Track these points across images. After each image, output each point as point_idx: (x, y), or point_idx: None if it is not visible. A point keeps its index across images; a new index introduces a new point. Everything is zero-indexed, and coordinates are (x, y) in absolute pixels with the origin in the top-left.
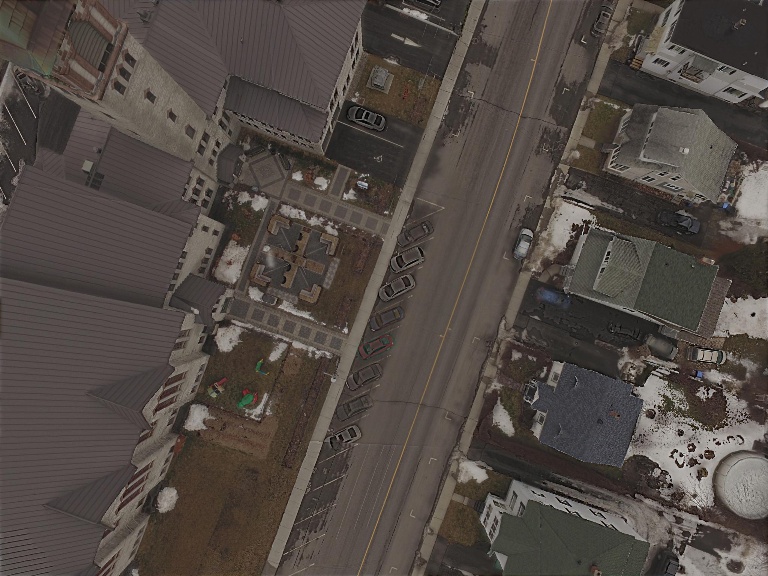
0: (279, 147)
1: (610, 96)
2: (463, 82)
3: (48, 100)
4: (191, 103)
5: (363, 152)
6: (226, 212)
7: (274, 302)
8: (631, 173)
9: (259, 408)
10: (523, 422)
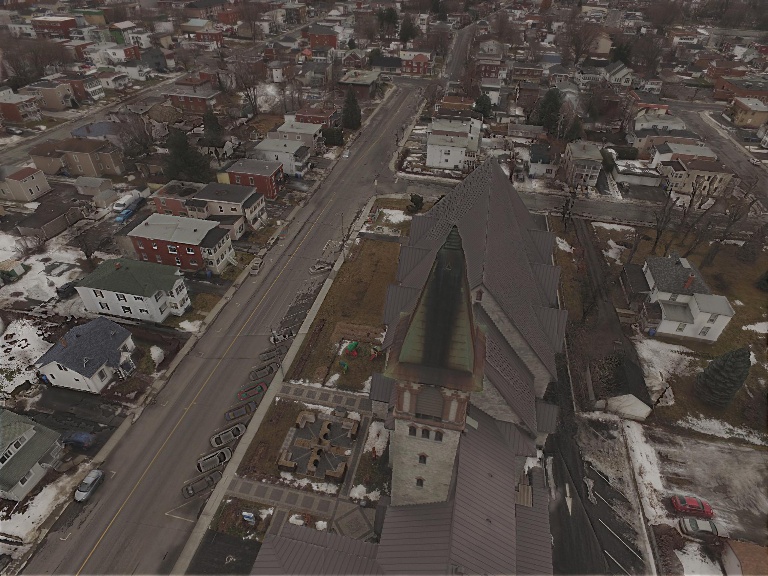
0: None
1: None
2: None
3: (603, 574)
4: None
5: (247, 565)
6: (390, 480)
7: None
8: None
9: (345, 346)
10: (141, 353)
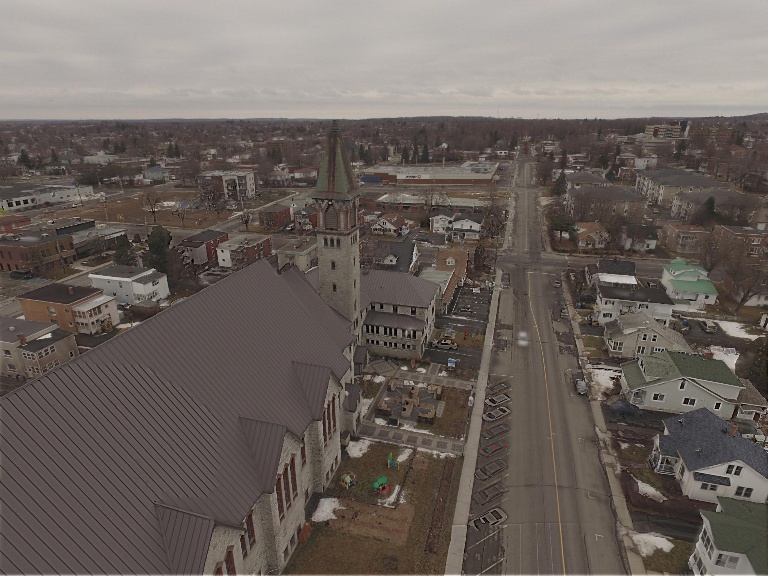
0: (390, 357)
1: (590, 334)
2: (498, 335)
3: None
4: (359, 292)
5: (446, 358)
6: None
7: (398, 420)
8: (627, 349)
9: (392, 497)
10: (670, 489)
